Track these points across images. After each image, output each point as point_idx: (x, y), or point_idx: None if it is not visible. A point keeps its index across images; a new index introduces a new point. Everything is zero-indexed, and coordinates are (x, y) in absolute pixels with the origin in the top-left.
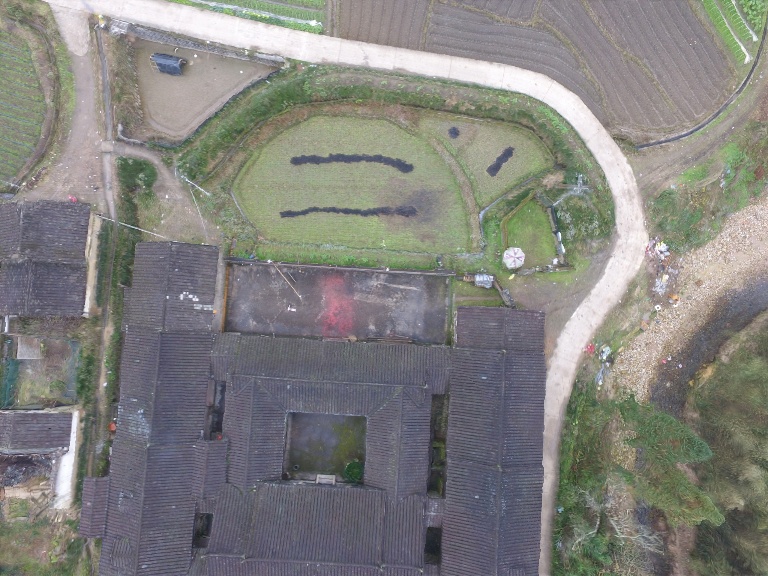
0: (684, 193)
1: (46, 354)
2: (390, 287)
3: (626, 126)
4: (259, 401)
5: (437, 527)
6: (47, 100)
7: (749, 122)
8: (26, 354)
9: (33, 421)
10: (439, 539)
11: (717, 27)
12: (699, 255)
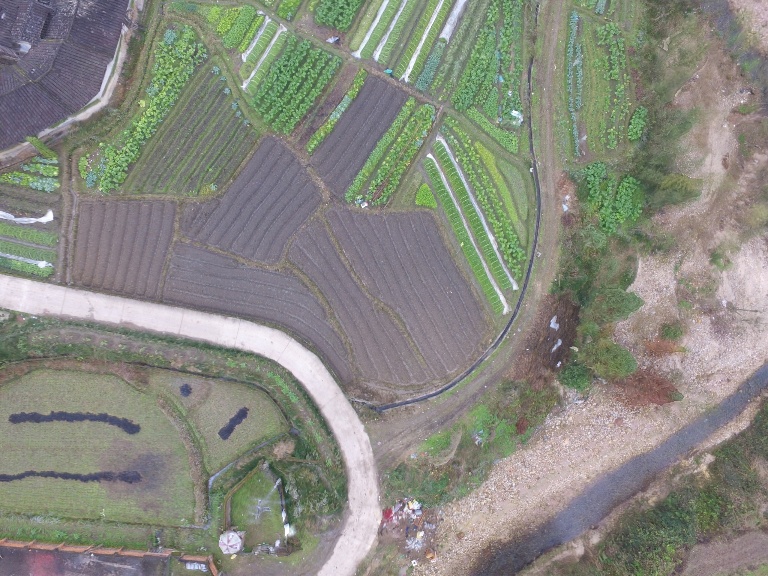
0: (423, 464)
1: None
2: (103, 565)
3: (373, 383)
4: None
5: None
6: None
7: (502, 381)
8: None
9: None
10: None
11: (476, 274)
12: (461, 505)
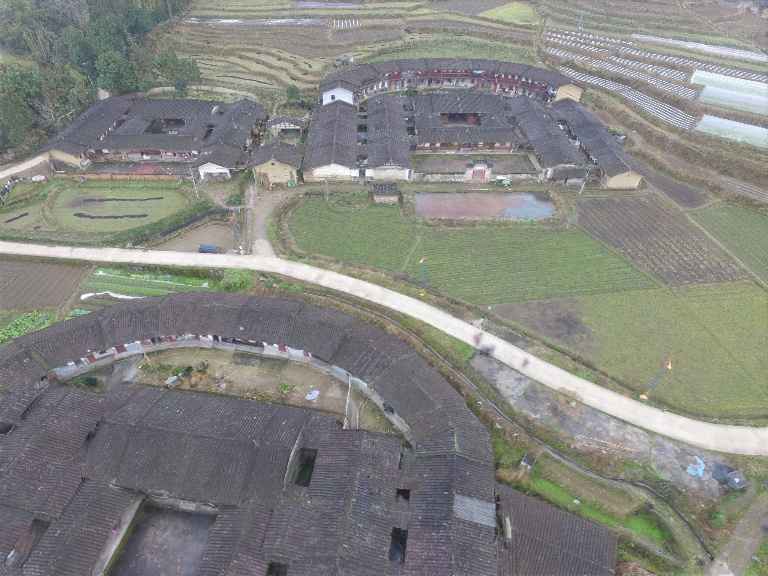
0: None
1: None
2: None
3: None
4: None
5: None
6: (286, 225)
7: None
8: None
9: None
10: None
11: None
12: None
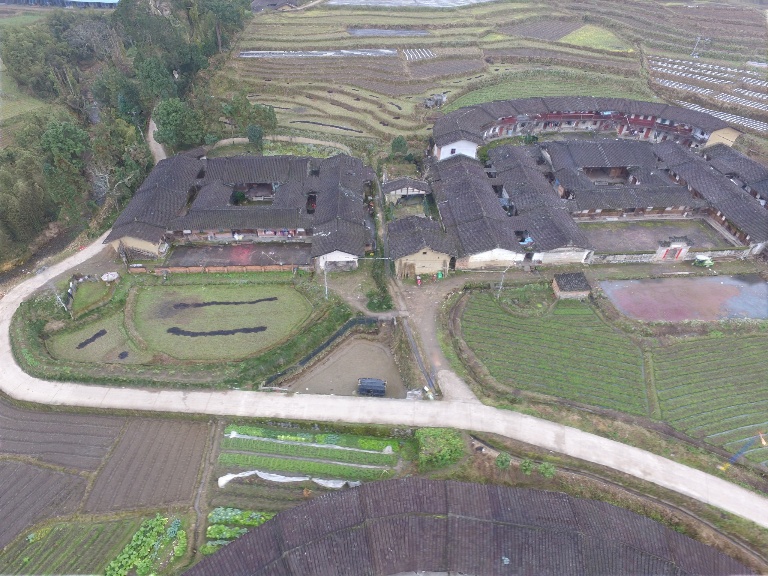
0: None
1: None
2: None
3: None
4: None
5: None
6: (463, 341)
7: None
8: (421, 216)
9: None
10: None
11: None
12: None
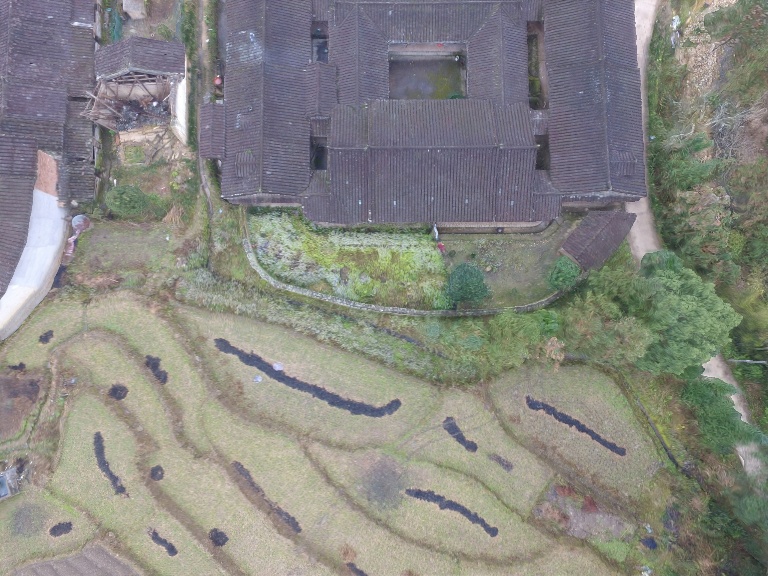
0: None
1: (149, 10)
2: None
3: None
4: (363, 27)
5: (543, 134)
6: None
7: None
8: (131, 6)
9: (149, 45)
10: (543, 155)
11: None
12: None
